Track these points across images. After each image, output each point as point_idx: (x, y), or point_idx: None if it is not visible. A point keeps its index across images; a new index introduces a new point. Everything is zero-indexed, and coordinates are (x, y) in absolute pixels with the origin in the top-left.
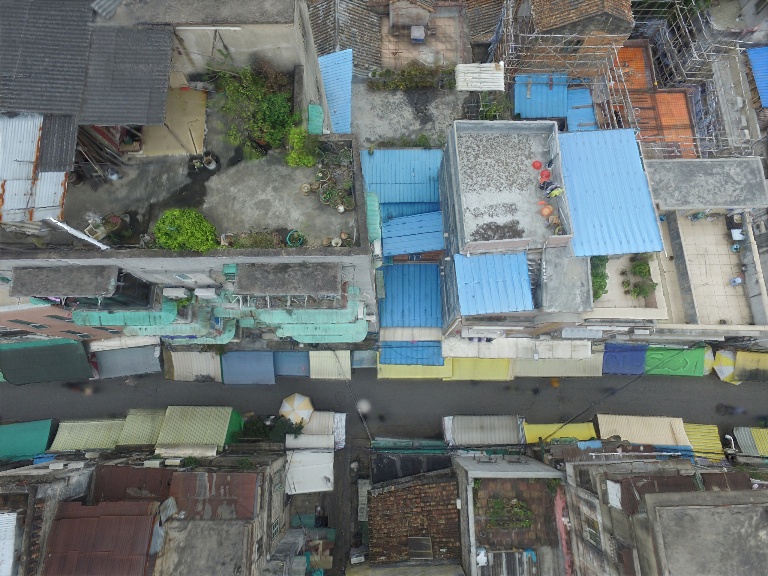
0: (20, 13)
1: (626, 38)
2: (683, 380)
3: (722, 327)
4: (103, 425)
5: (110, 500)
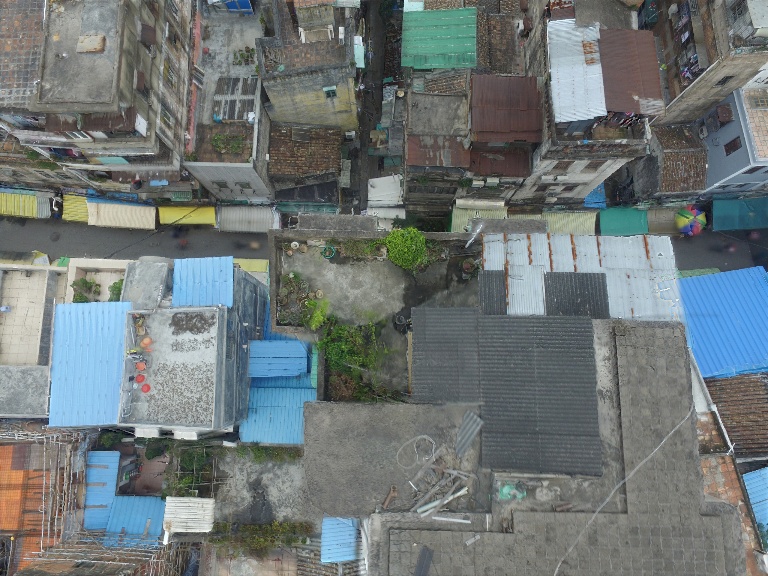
0: (543, 412)
1: (26, 567)
2: None
3: (30, 267)
4: None
5: (516, 152)
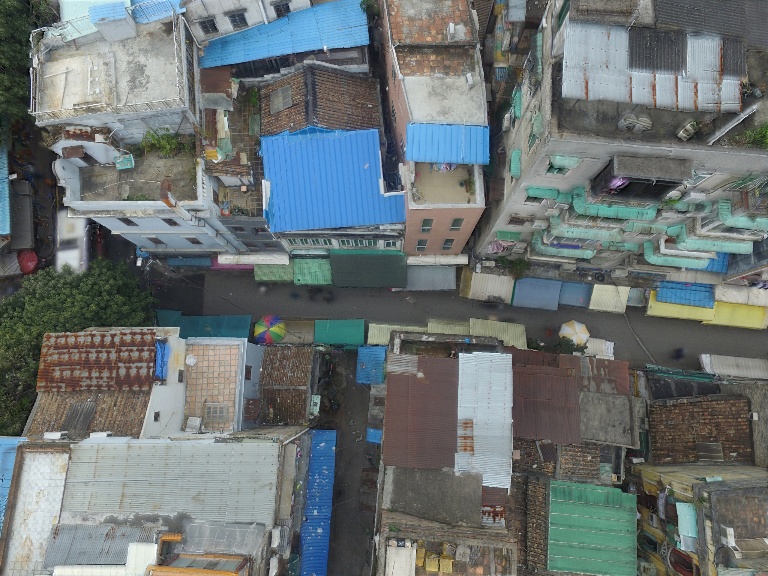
0: None
1: None
2: None
3: None
4: (406, 329)
5: None
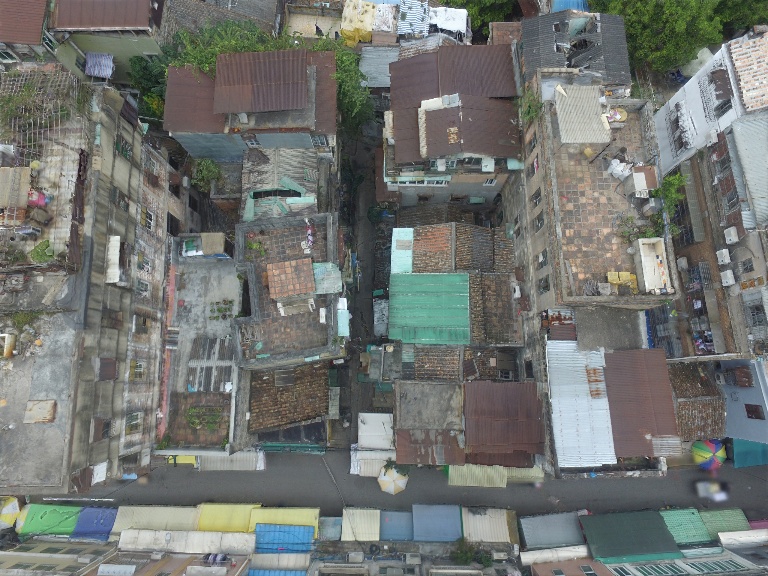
0: None
1: None
2: None
3: None
4: None
5: None
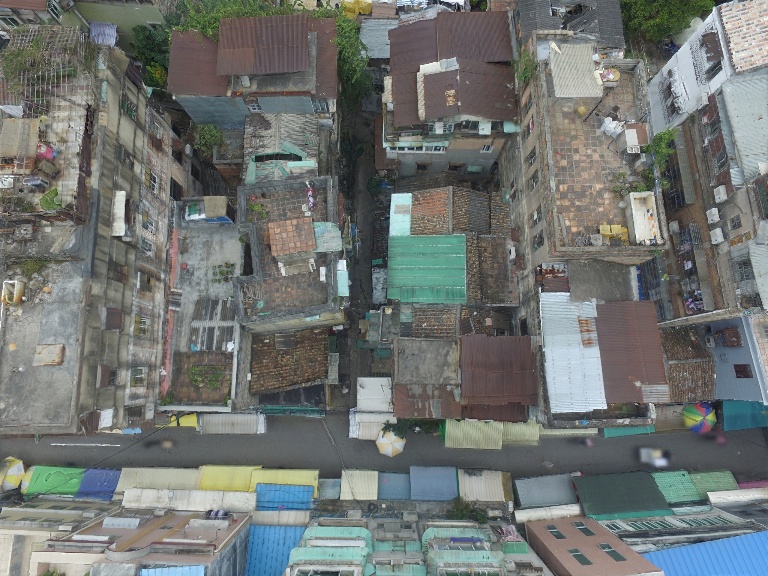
0: None
1: None
2: (57, 458)
3: None
4: (559, 431)
5: None
